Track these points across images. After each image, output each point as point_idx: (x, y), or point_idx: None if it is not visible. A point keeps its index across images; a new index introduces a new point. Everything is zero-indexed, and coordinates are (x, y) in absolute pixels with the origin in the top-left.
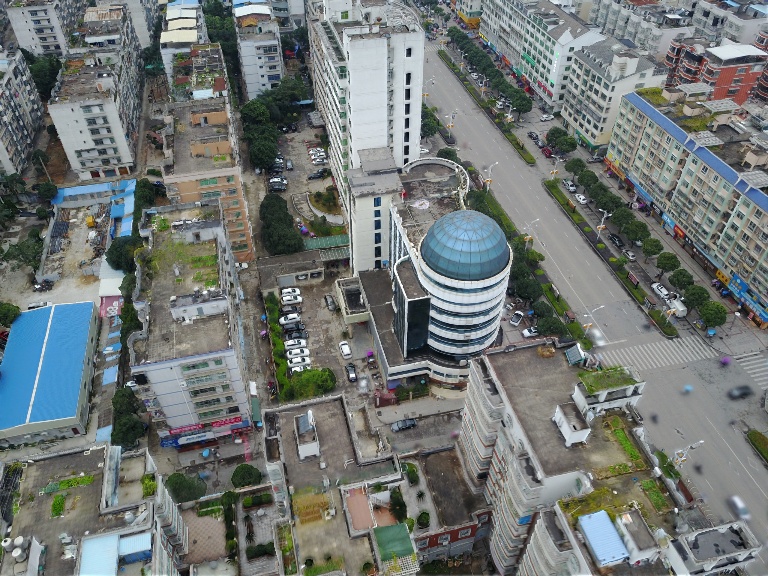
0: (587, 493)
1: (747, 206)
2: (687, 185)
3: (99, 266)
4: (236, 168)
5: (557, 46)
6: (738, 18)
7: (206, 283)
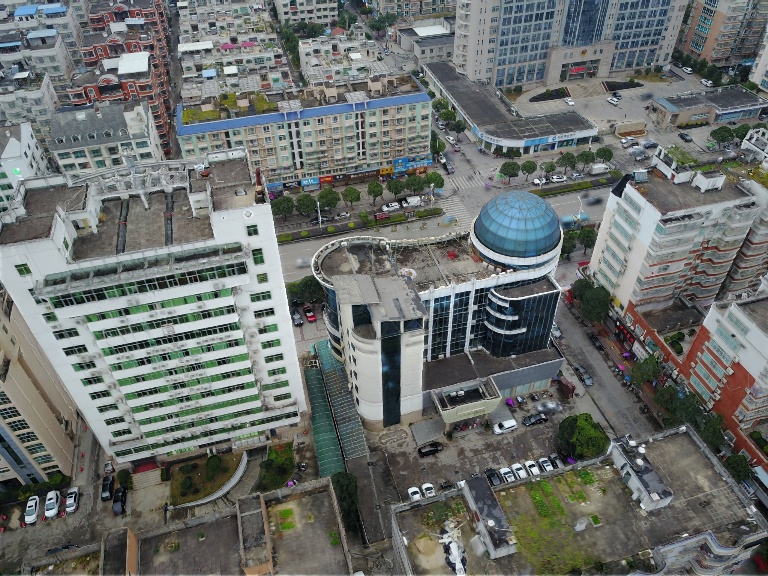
0: (749, 186)
1: (374, 115)
2: (311, 144)
3: None
4: (329, 479)
5: (9, 163)
6: (46, 50)
7: (588, 483)
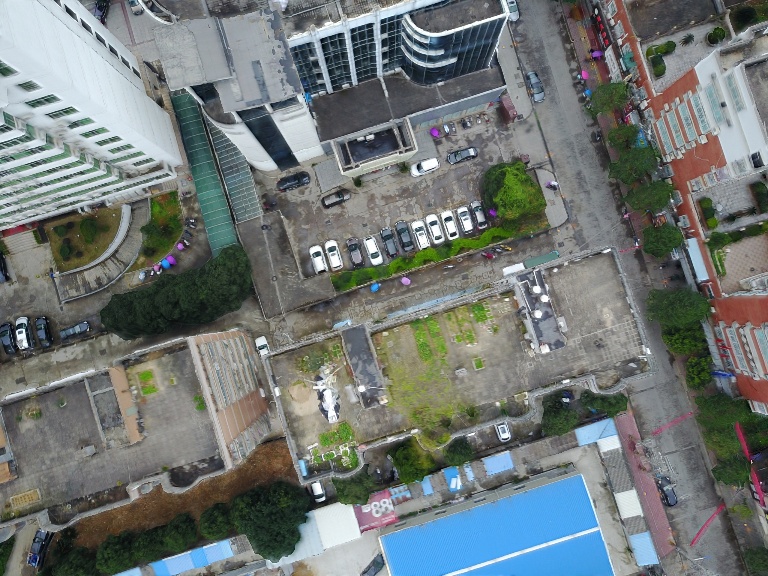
0: None
1: None
2: None
3: (283, 569)
4: (188, 339)
5: None
6: None
7: (481, 320)
